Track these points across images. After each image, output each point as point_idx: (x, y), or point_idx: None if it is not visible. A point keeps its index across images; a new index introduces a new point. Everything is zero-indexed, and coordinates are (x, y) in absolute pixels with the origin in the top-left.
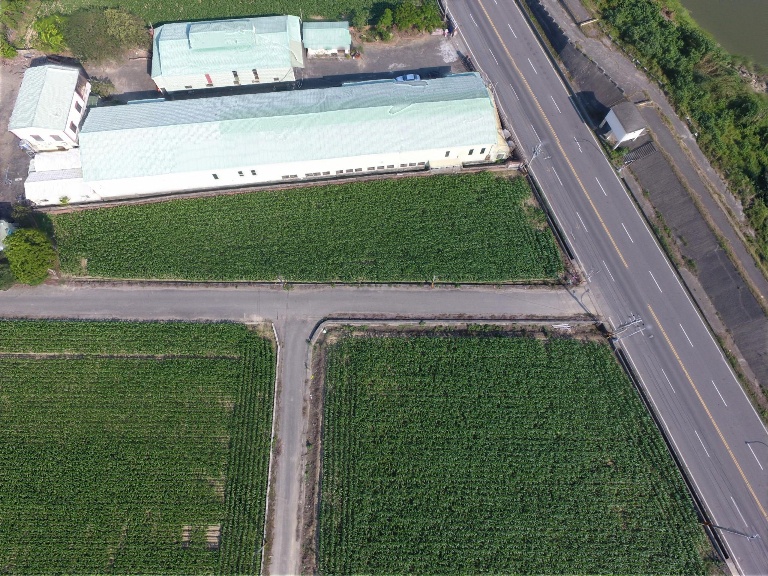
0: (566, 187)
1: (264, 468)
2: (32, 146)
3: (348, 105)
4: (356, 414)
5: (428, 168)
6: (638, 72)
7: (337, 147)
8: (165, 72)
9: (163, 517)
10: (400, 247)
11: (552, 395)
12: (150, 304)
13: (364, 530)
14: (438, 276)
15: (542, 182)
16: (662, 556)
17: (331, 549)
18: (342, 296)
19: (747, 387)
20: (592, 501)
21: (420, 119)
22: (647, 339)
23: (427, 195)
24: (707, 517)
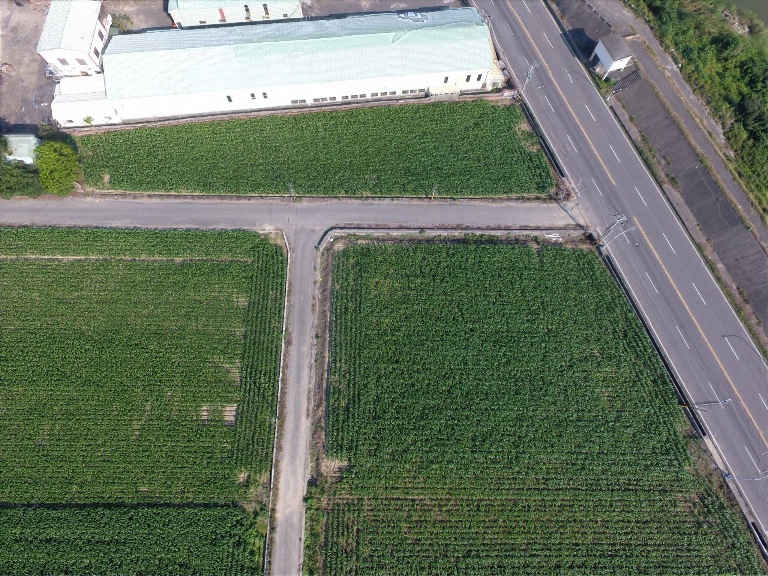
0: (557, 113)
1: (277, 356)
2: (58, 70)
3: (353, 32)
4: (361, 310)
5: (428, 95)
6: (626, 9)
7: (343, 71)
8: (181, 6)
9: (184, 398)
10: (402, 165)
11: (543, 294)
12: (169, 214)
13: (369, 409)
14: (437, 191)
15: (535, 109)
16: (644, 433)
17: (339, 425)
18: (348, 208)
19: (725, 289)
20: (580, 386)
21: (421, 38)
22: (632, 246)
23: (427, 119)
24: (686, 400)
